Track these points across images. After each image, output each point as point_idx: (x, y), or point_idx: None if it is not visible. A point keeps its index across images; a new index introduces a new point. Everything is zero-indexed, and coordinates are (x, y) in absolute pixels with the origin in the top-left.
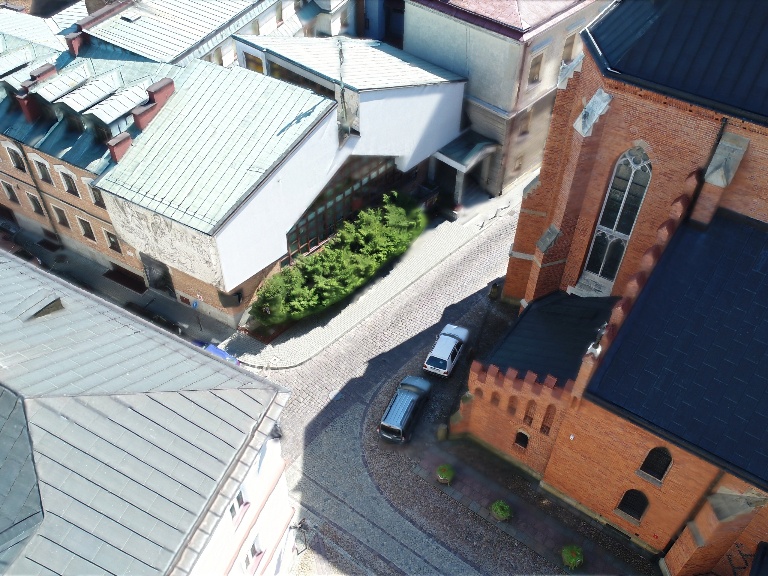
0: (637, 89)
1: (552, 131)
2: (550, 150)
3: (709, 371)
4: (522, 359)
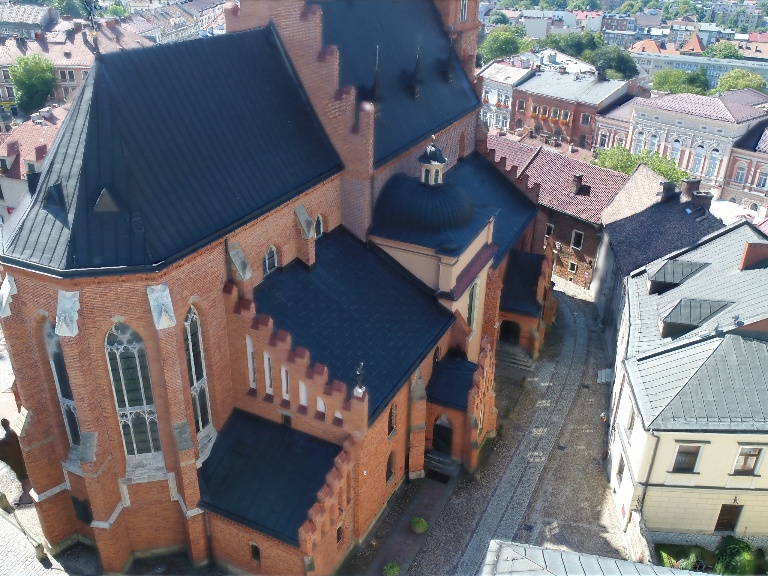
0: (180, 262)
1: (86, 378)
2: (91, 396)
3: (354, 355)
4: (286, 501)
